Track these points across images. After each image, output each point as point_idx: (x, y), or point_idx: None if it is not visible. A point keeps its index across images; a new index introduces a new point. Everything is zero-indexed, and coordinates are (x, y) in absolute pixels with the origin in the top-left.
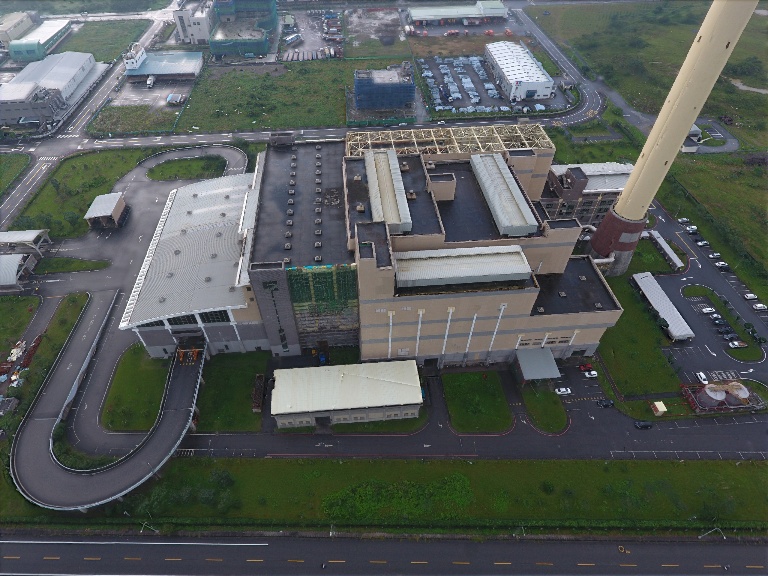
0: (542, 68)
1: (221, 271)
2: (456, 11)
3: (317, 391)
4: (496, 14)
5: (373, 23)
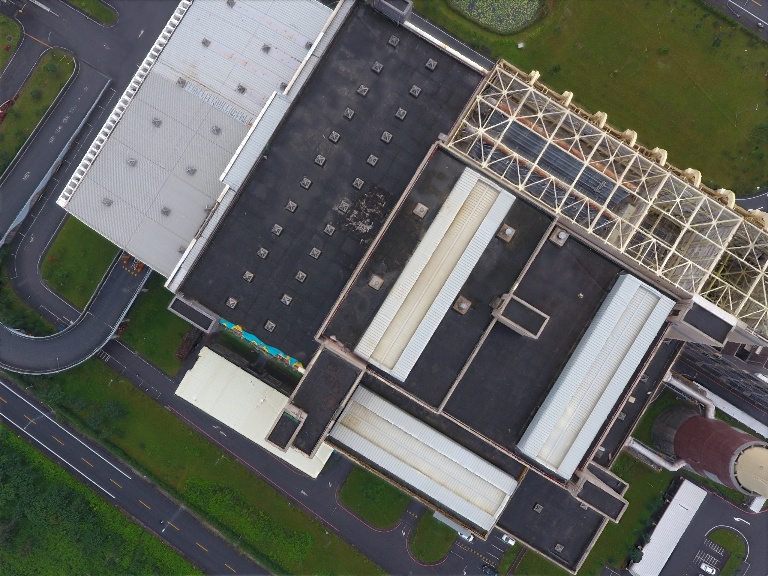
0: None
1: (187, 207)
2: None
3: (228, 401)
4: None
5: None
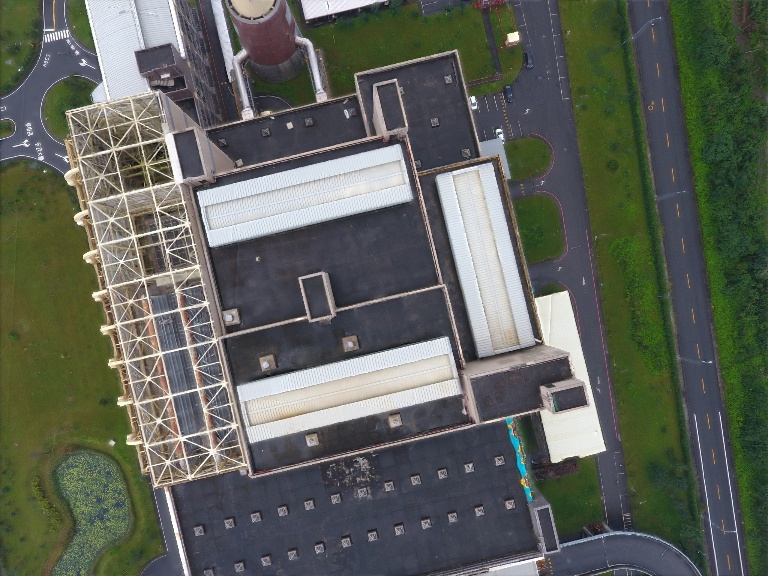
0: None
1: None
2: None
3: None
4: None
5: None
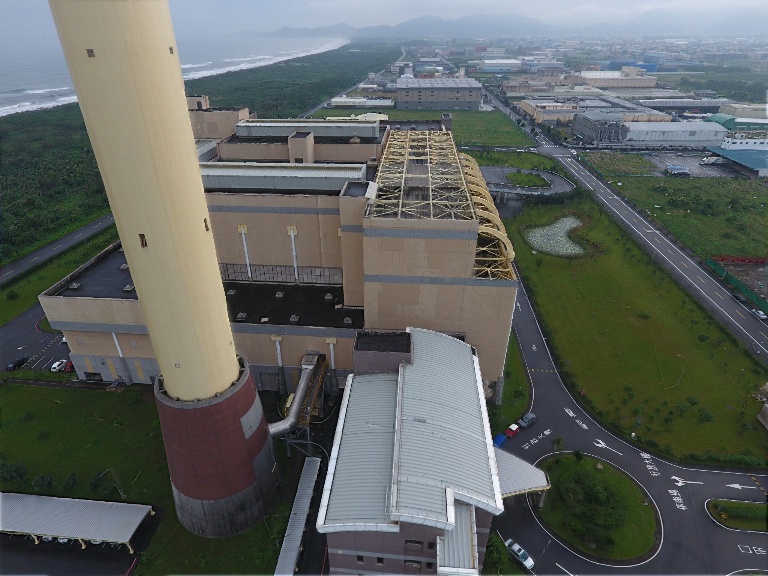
0: None
1: None
2: None
3: None
4: None
5: None
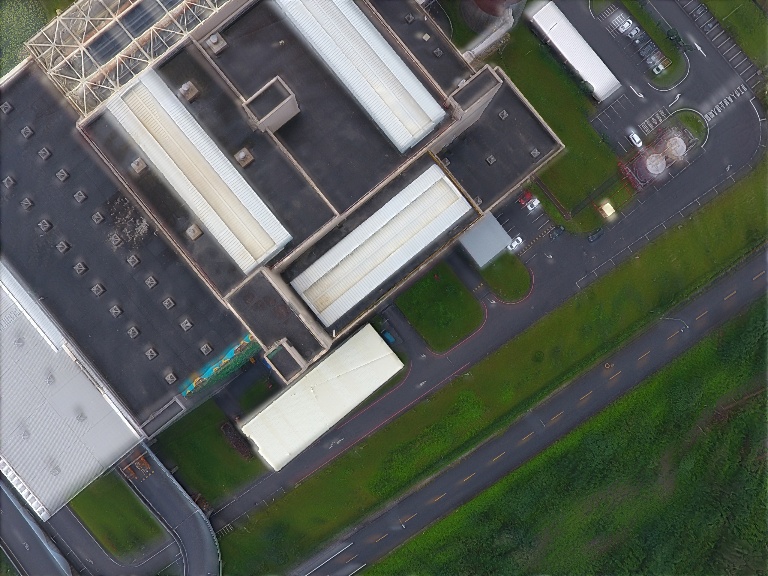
0: None
1: (84, 396)
2: None
3: (301, 424)
4: None
5: None
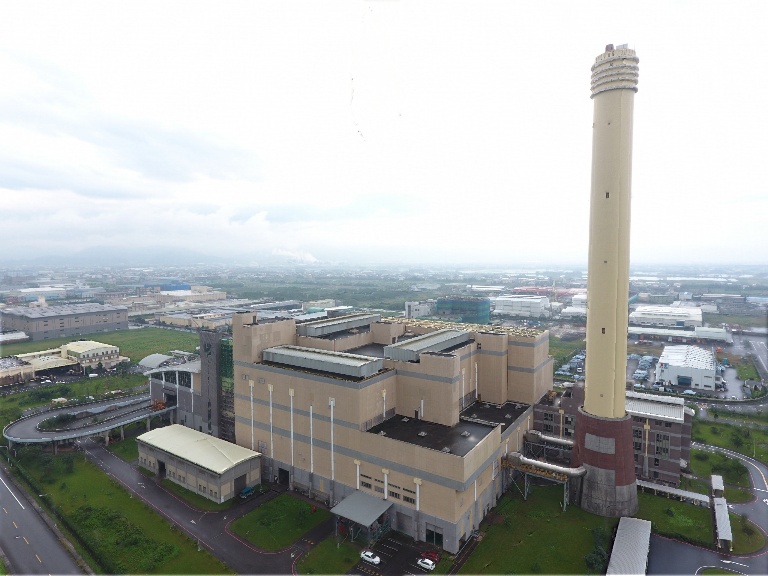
0: (714, 363)
1: None
2: (663, 331)
3: (176, 438)
4: (714, 337)
5: (569, 331)
